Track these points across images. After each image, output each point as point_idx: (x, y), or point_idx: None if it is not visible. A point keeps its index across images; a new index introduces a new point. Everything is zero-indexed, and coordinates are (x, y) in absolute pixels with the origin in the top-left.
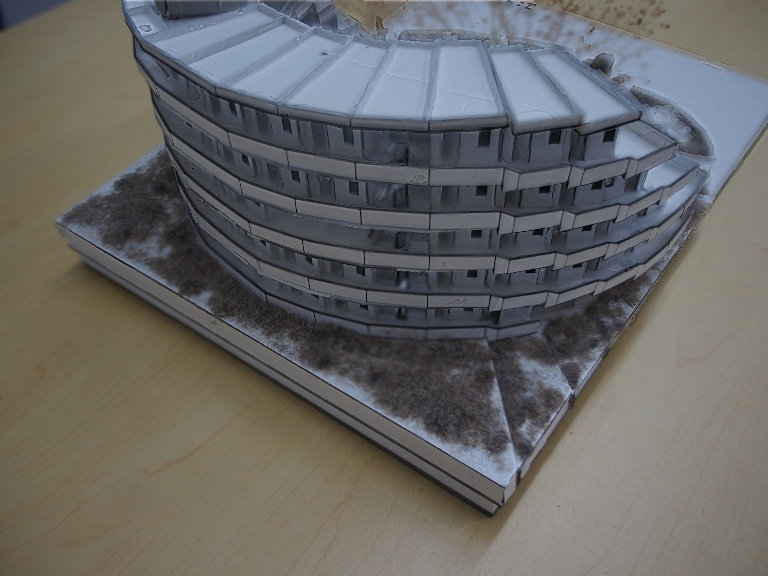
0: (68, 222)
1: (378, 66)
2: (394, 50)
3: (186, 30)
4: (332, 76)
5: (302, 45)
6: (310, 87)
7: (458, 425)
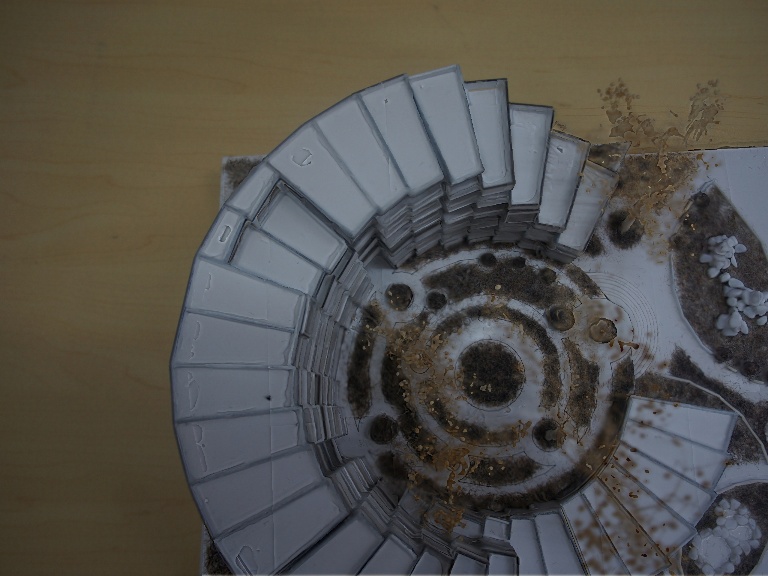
0: (227, 171)
1: (268, 456)
2: (301, 450)
3: (235, 270)
4: (241, 427)
5: (270, 372)
6: (219, 422)
7: (221, 568)
